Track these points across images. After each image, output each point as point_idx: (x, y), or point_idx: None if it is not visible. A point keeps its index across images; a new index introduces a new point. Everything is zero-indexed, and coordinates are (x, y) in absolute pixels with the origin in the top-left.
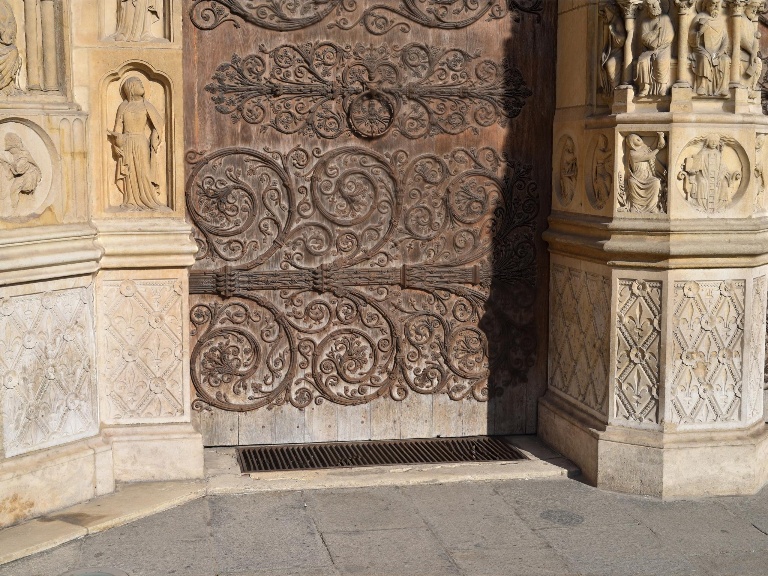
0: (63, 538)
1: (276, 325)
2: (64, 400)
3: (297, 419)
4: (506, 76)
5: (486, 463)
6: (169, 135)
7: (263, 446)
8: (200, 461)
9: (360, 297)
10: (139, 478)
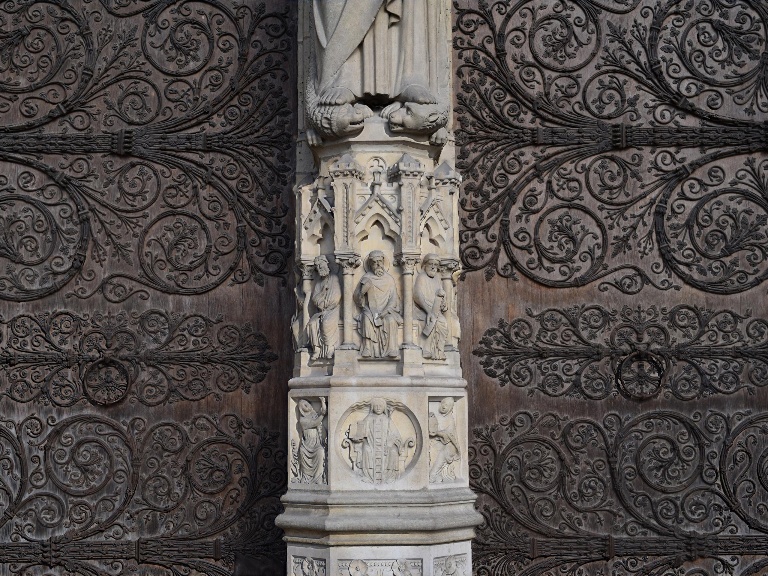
0: None
1: None
2: None
3: None
4: (250, 340)
5: None
6: None
7: None
8: None
9: (93, 572)
10: None
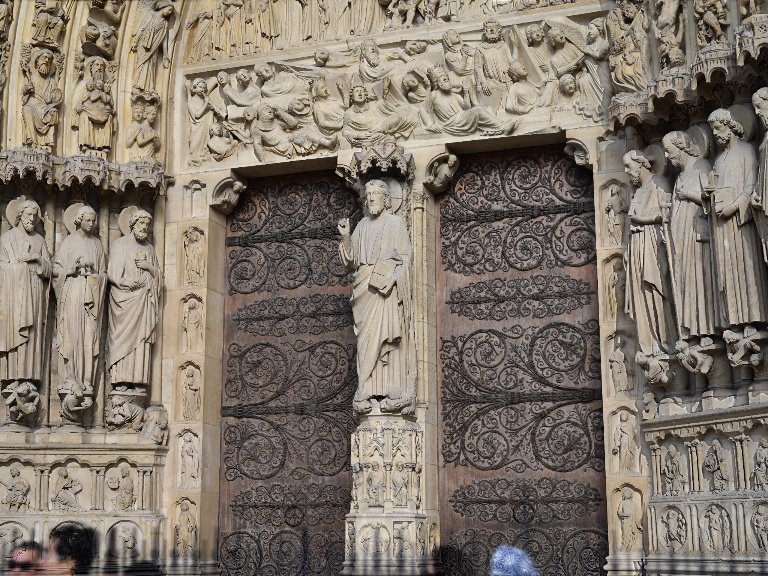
0: None
1: None
2: None
3: None
4: None
5: None
6: None
7: None
8: None
9: None
10: None
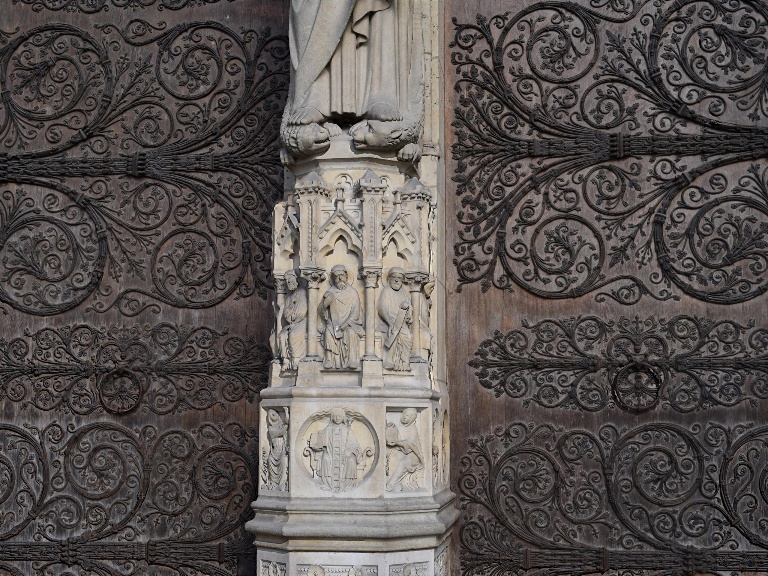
0: None
1: None
2: None
3: None
4: (253, 352)
5: None
6: None
7: None
8: None
9: (107, 571)
10: None
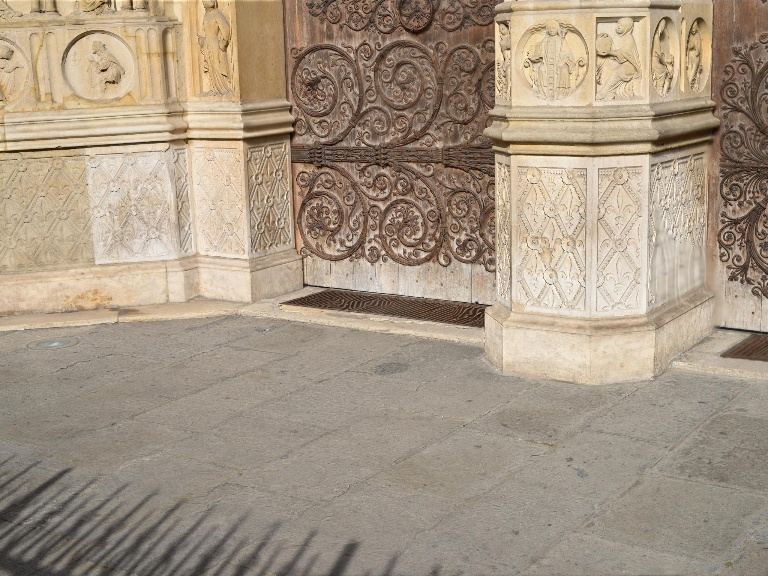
0: (96, 320)
1: (354, 192)
2: (146, 231)
3: (370, 272)
4: None
5: (448, 325)
6: None
7: (346, 291)
8: (249, 290)
9: (412, 172)
10: (215, 296)
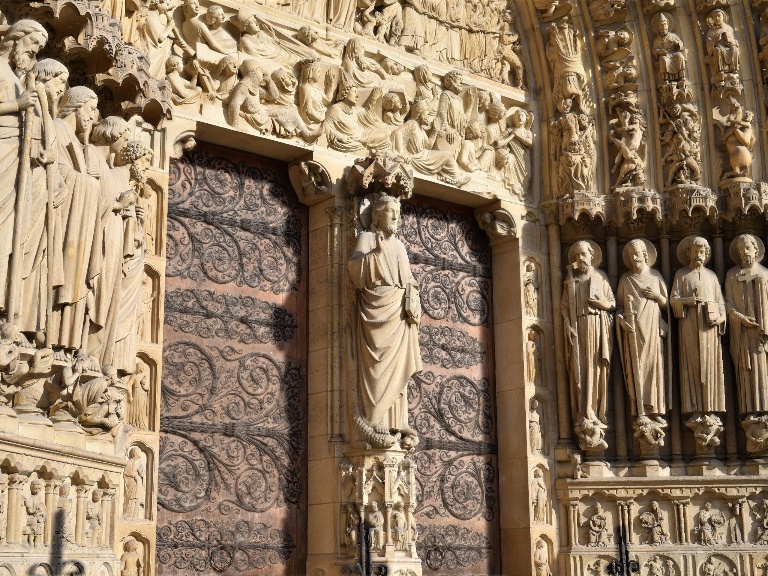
0: None
1: None
2: None
3: None
4: (284, 537)
5: None
6: (147, 570)
7: None
8: None
9: None
10: None
